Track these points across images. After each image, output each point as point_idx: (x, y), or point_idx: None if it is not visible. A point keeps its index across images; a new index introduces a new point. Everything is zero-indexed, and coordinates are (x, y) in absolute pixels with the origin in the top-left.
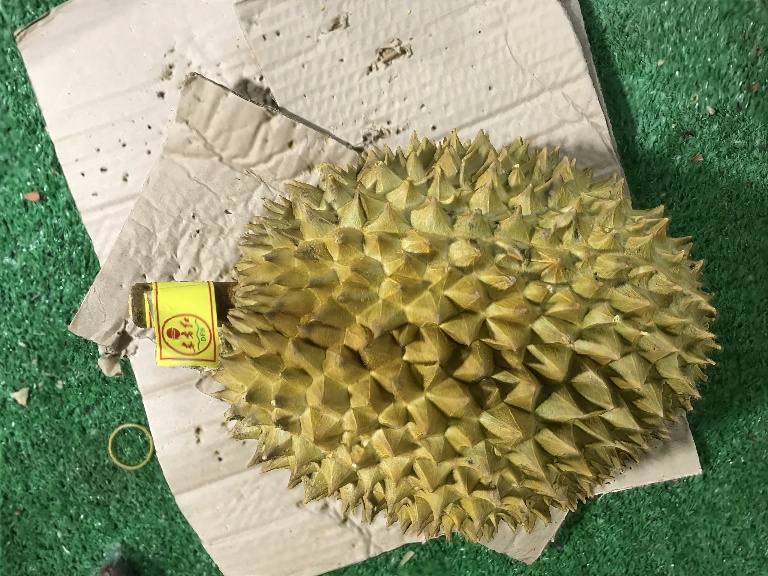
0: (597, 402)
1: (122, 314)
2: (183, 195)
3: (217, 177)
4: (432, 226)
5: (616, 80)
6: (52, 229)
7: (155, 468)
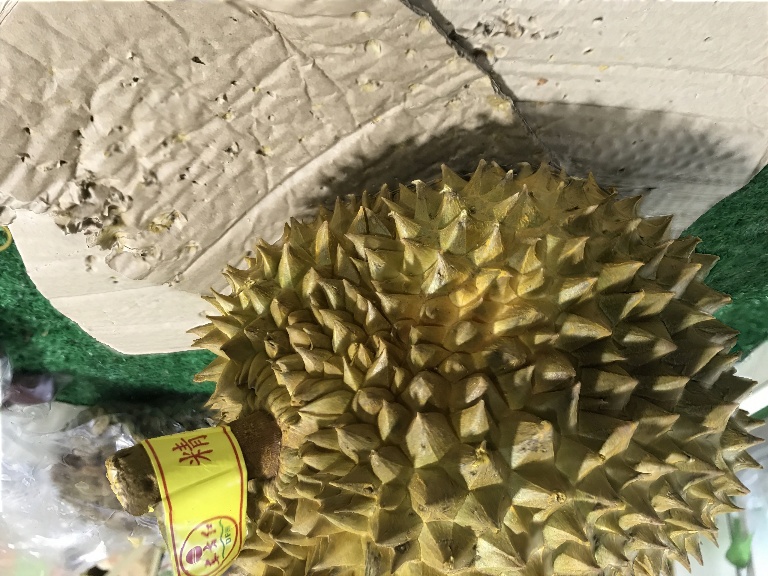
0: None
1: None
2: (117, 21)
3: (193, 7)
4: (574, 570)
5: None
6: None
7: (14, 252)
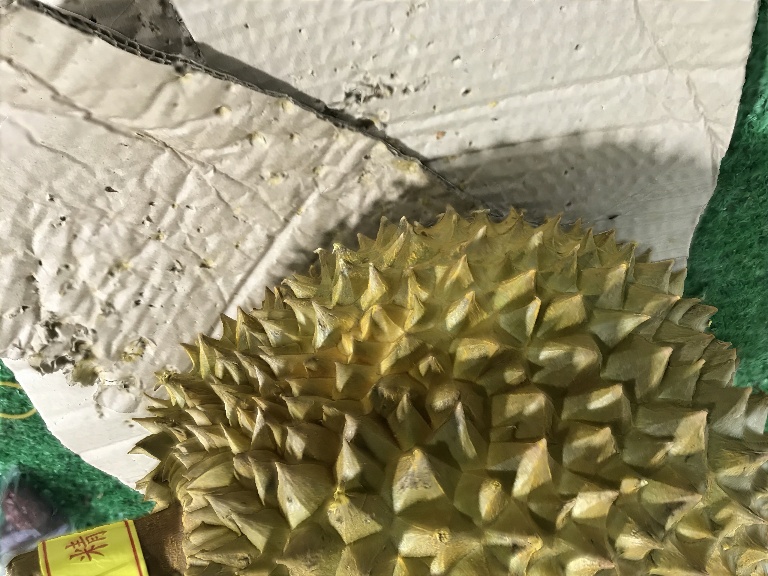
0: None
1: None
2: (26, 169)
3: (84, 142)
4: None
5: (767, 30)
6: None
7: None
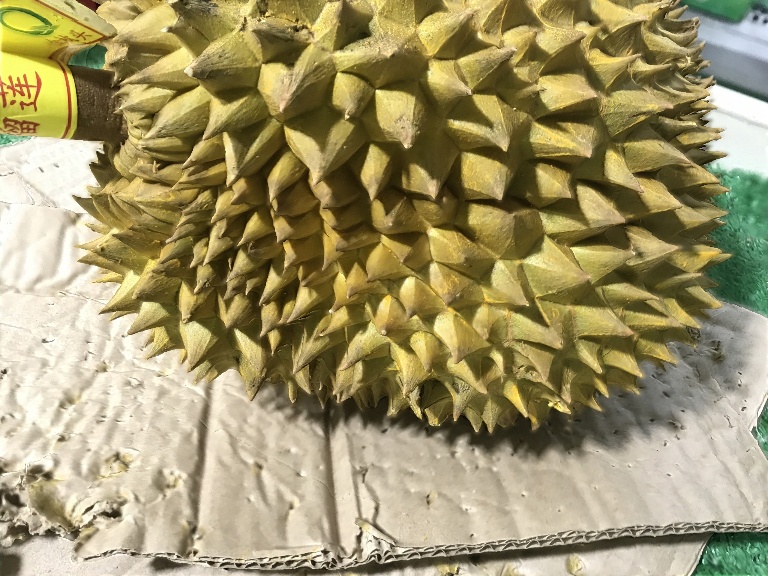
0: None
1: None
2: None
3: (18, 310)
4: None
5: None
6: None
7: None
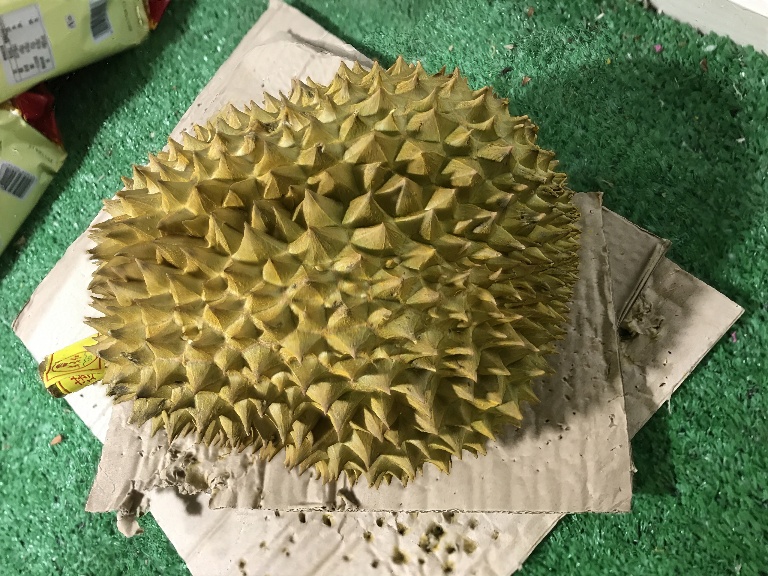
0: (394, 187)
1: (128, 477)
2: None
3: None
4: None
5: None
6: (77, 458)
7: None
